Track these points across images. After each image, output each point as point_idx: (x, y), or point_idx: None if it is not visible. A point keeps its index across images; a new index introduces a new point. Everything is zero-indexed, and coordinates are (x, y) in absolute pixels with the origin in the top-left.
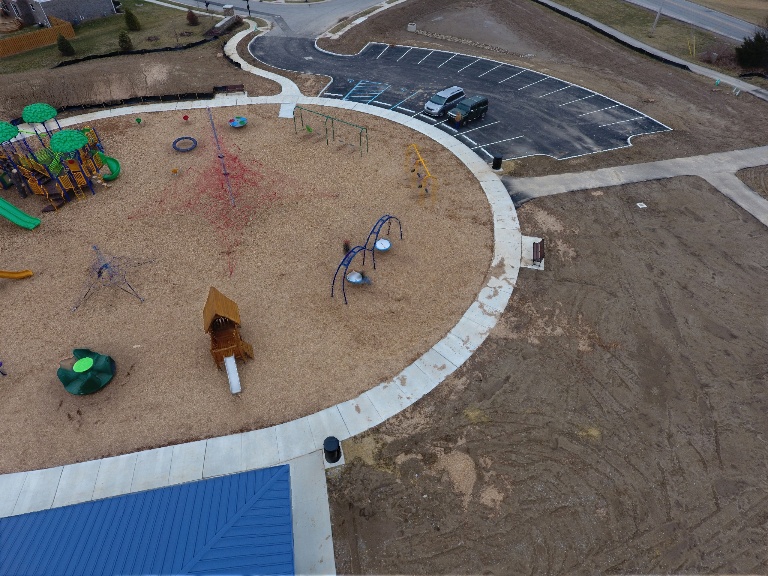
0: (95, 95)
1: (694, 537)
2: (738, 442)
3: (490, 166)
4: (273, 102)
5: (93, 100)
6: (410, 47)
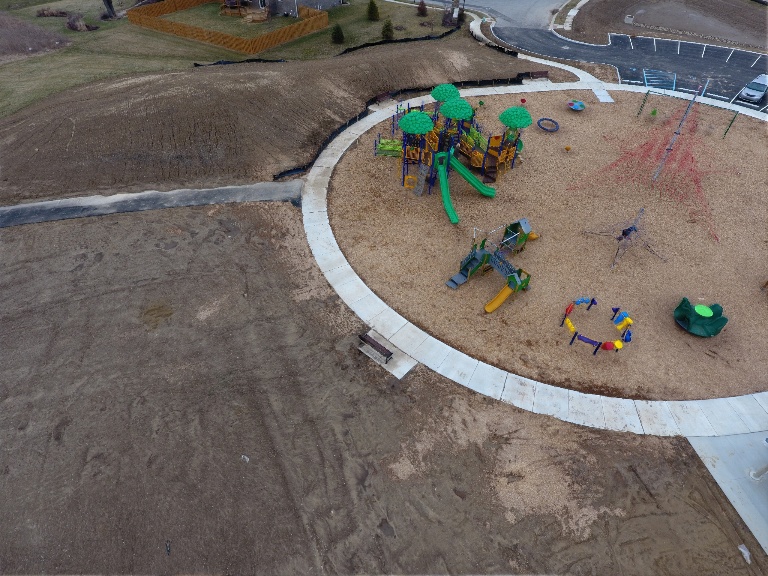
0: (419, 79)
1: None
2: None
3: None
4: (583, 88)
5: (419, 84)
6: (653, 38)
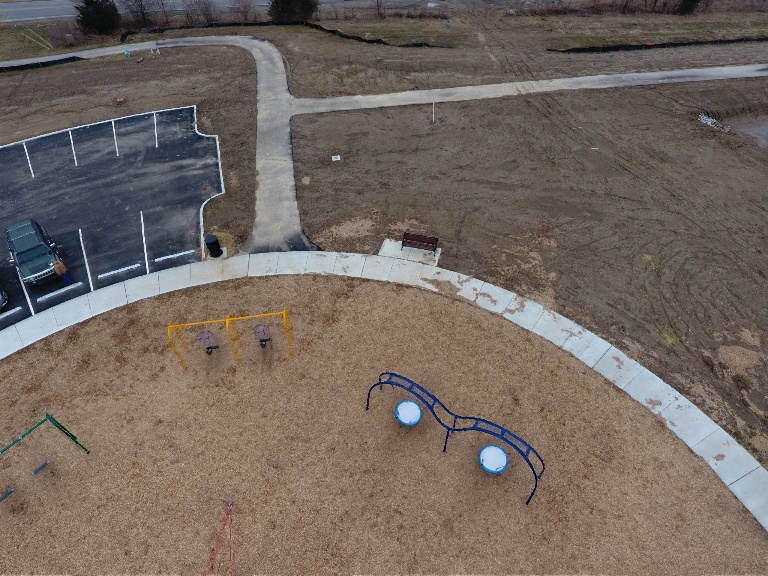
0: None
1: (709, 230)
2: (619, 189)
3: (209, 259)
4: None
5: None
6: None
